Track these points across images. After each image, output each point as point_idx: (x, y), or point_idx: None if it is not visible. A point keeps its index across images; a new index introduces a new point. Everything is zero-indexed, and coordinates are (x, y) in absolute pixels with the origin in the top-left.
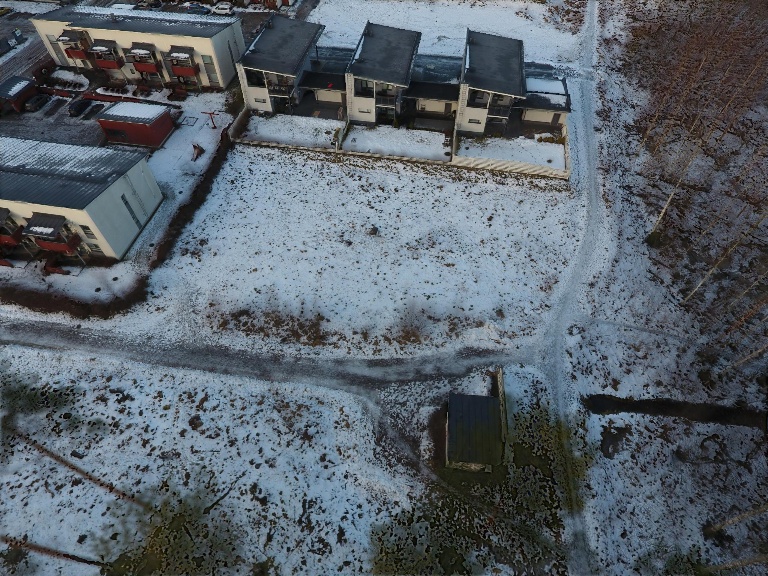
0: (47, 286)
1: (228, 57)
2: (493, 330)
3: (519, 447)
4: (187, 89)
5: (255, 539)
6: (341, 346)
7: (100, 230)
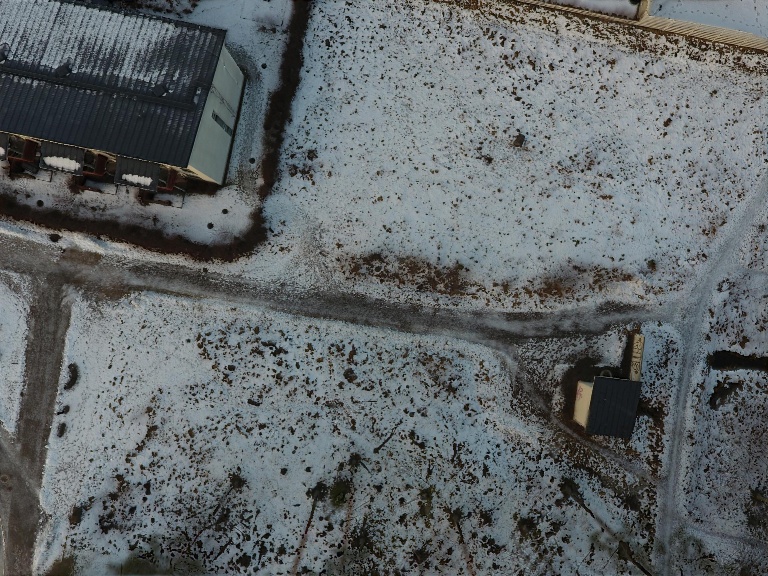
0: (152, 220)
1: None
2: (640, 285)
3: (639, 401)
4: None
5: (418, 472)
6: (480, 297)
7: (203, 172)
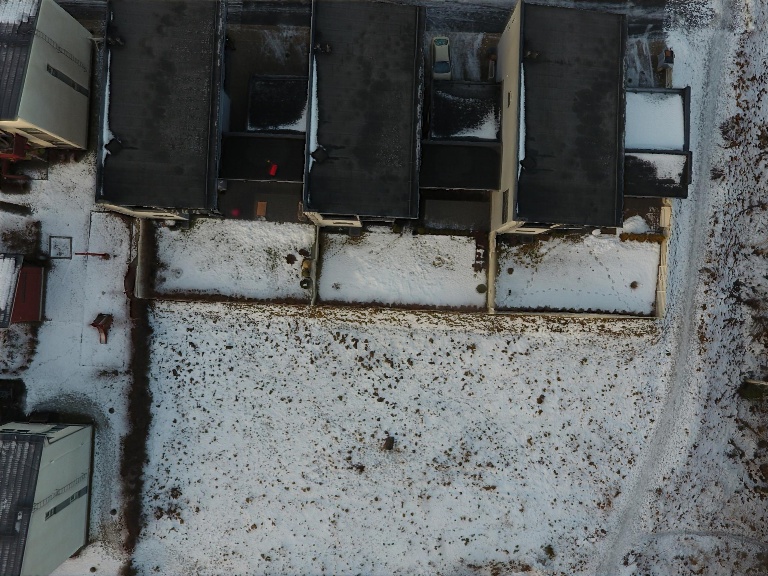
0: None
1: (63, 92)
2: (541, 575)
3: None
4: (21, 161)
5: None
6: None
7: (46, 575)
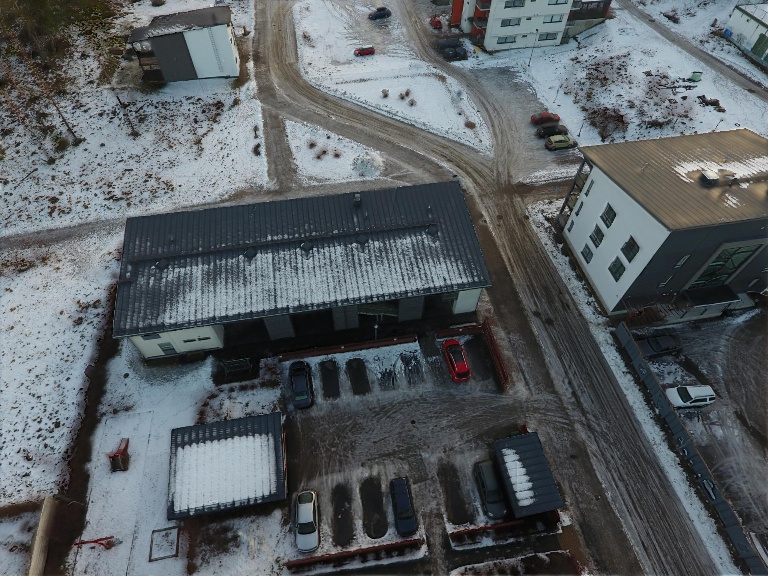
0: None
1: None
2: None
3: None
4: None
5: (4, 167)
6: None
7: None
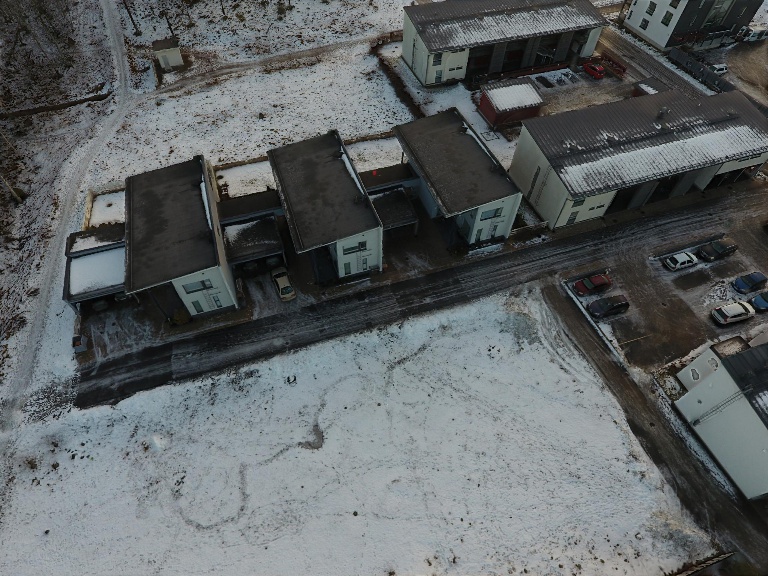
0: None
1: (530, 174)
2: None
3: None
4: None
5: (249, 24)
6: None
7: None
